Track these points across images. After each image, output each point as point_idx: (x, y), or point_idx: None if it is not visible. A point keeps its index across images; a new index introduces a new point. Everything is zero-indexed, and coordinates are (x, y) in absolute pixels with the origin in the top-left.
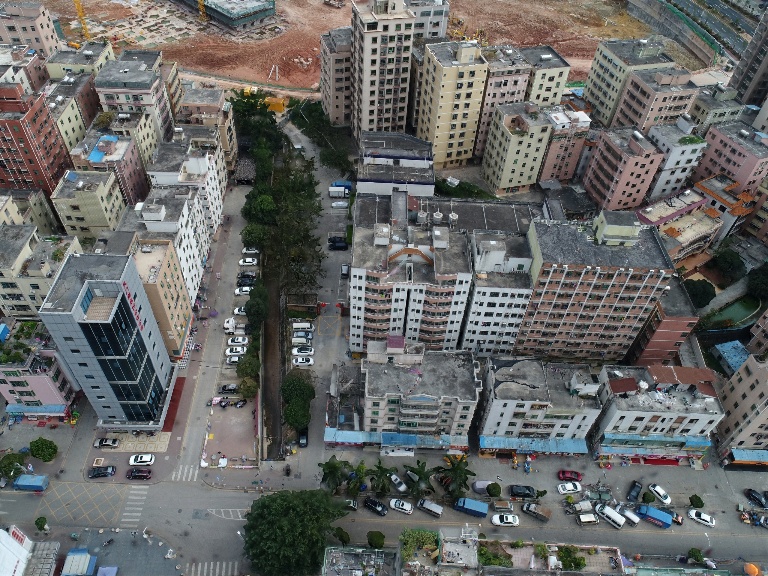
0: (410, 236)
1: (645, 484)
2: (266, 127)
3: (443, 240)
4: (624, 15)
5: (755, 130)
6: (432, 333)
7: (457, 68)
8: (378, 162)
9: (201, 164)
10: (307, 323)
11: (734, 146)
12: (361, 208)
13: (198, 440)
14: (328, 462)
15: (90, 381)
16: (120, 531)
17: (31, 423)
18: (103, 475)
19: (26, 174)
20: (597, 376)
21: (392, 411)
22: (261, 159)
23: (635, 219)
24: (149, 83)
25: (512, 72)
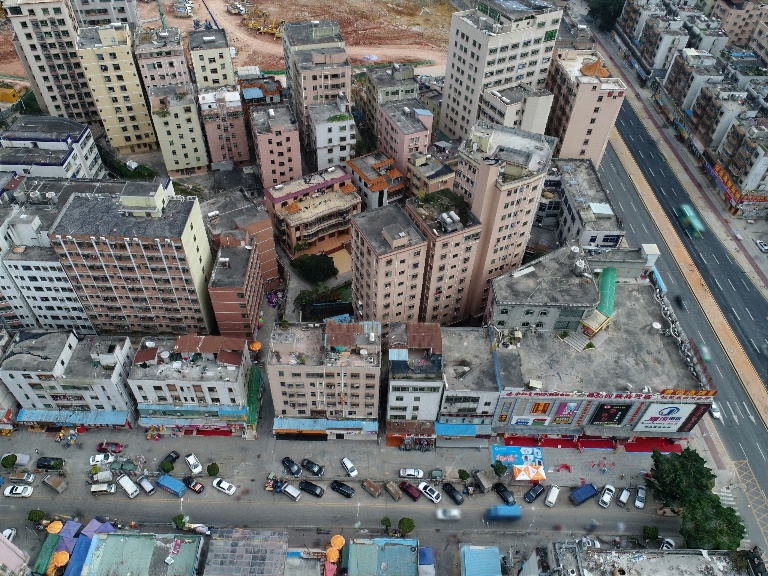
0: None
1: (185, 454)
2: None
3: None
4: (445, 4)
5: (423, 107)
6: None
7: (93, 50)
8: (16, 145)
9: None
10: None
11: (392, 123)
12: None
13: None
14: None
15: None
16: None
17: None
18: None
19: None
20: (115, 346)
21: None
22: None
23: (155, 190)
24: None
25: (162, 54)
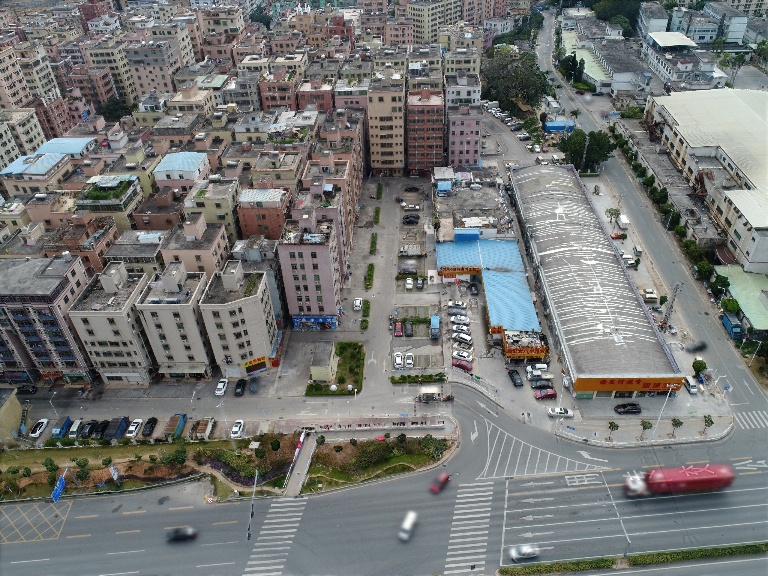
0: None
1: None
2: None
3: None
4: None
5: None
6: None
7: None
8: None
9: None
10: None
11: None
12: None
13: None
14: (249, 15)
15: None
16: None
17: None
18: None
19: None
20: None
21: None
22: None
23: None
24: None
25: None
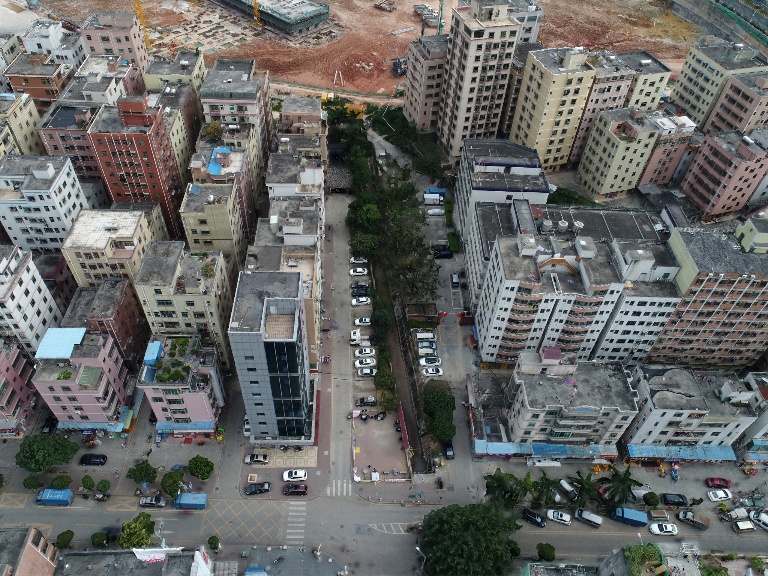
0: (554, 246)
1: None
2: (359, 135)
3: (590, 250)
4: (670, 15)
5: None
6: (570, 342)
7: (566, 75)
8: (489, 170)
9: (317, 175)
10: (430, 333)
11: None
12: (483, 217)
13: (345, 454)
14: (494, 475)
15: (255, 398)
16: (288, 548)
17: (177, 440)
18: (260, 492)
19: (144, 187)
20: (750, 384)
21: (547, 422)
22: (360, 168)
23: None
24: (255, 93)
25: (617, 78)
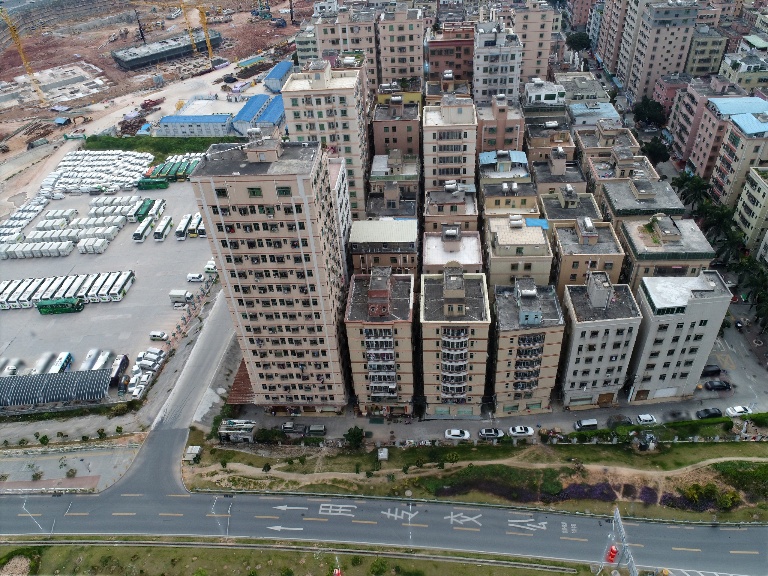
0: None
1: None
2: None
3: None
4: None
5: None
6: None
7: None
8: None
9: None
10: None
11: None
12: None
13: None
14: None
15: None
16: None
17: None
18: None
19: None
20: None
21: None
22: None
23: None
24: None
25: None
